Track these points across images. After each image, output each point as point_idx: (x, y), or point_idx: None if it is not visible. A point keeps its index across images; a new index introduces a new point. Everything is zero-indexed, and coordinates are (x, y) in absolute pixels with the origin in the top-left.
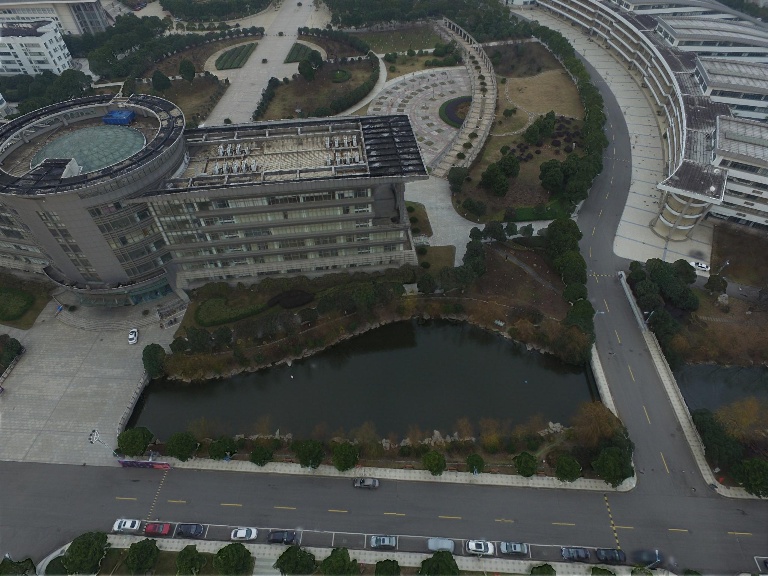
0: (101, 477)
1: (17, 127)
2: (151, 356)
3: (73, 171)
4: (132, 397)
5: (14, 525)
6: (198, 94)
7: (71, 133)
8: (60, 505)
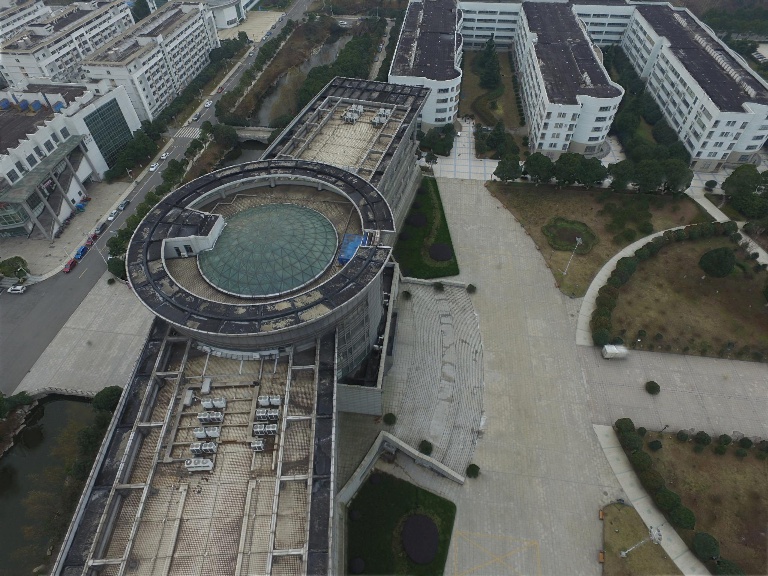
0: (6, 388)
1: (316, 172)
2: (100, 395)
3: (197, 244)
4: (76, 390)
5: (6, 341)
6: (740, 322)
7: (296, 217)
8: (1, 366)
